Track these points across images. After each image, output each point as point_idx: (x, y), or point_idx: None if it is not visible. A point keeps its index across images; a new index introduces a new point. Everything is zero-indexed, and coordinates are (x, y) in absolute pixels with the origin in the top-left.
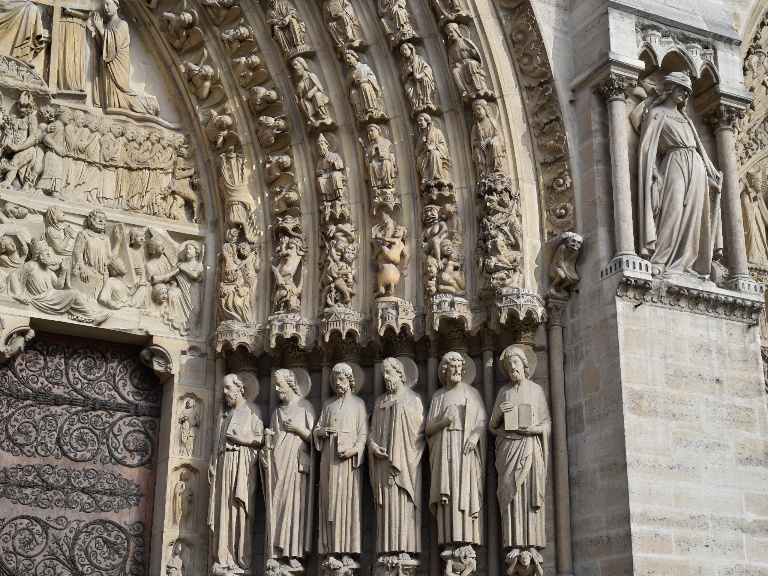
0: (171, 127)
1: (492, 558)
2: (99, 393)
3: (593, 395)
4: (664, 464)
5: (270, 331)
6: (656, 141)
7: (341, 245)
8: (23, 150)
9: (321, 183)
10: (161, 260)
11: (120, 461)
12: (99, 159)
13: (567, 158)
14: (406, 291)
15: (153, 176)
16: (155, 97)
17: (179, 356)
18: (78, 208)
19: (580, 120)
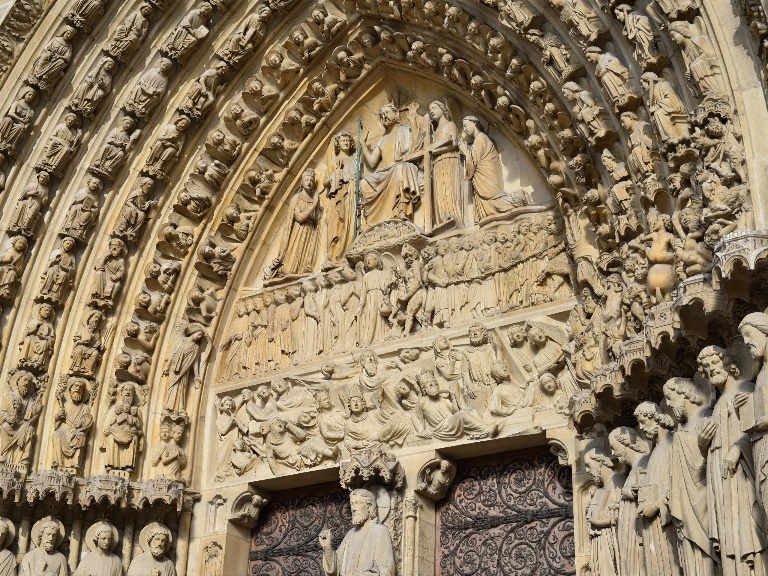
0: (544, 209)
1: None
2: (531, 504)
3: None
4: None
5: None
6: None
7: (627, 265)
8: (412, 297)
9: (608, 204)
10: (548, 348)
11: (558, 571)
12: (478, 274)
13: None
14: None
15: (527, 267)
16: (531, 187)
17: (574, 443)
18: (464, 329)
19: None
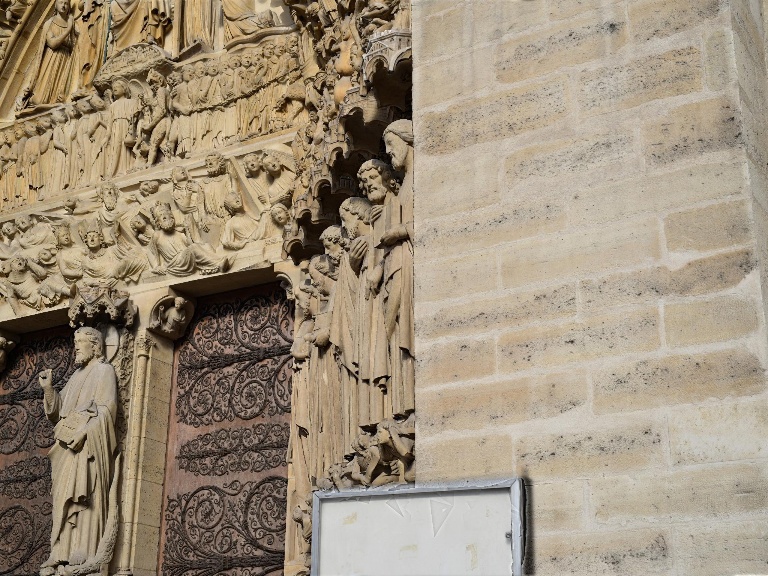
0: (290, 30)
1: None
2: (264, 341)
3: None
4: (486, 219)
5: None
6: None
7: (328, 80)
8: (156, 126)
9: (320, 16)
10: (283, 178)
11: (285, 409)
12: None
13: None
14: None
15: (269, 92)
16: (281, 7)
17: (300, 277)
18: (203, 159)
19: None
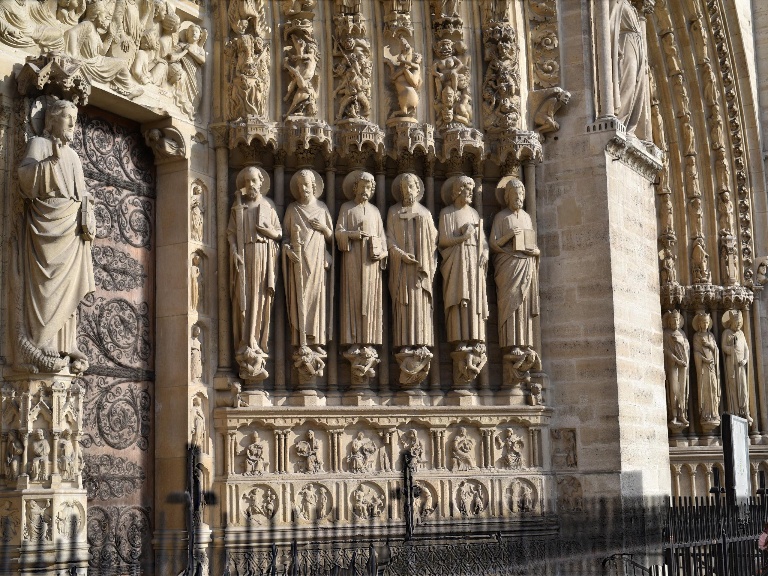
0: None
1: (485, 354)
2: (110, 168)
3: (573, 227)
4: (625, 288)
5: (304, 132)
6: (620, 22)
7: (364, 60)
8: None
9: None
10: (171, 38)
11: (129, 240)
12: None
13: (554, 21)
14: (419, 114)
15: None
16: None
17: (190, 141)
18: None
19: None
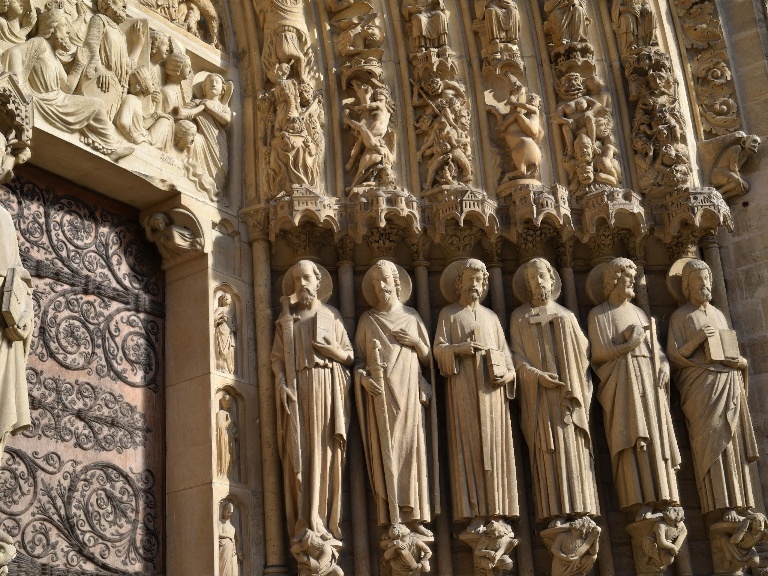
0: None
1: None
2: (90, 269)
3: None
4: None
5: (376, 204)
6: None
7: (458, 105)
8: None
9: (423, 21)
10: (179, 88)
11: (121, 375)
12: None
13: (721, 47)
14: (543, 177)
15: None
16: None
17: (211, 229)
18: None
19: (731, 7)
